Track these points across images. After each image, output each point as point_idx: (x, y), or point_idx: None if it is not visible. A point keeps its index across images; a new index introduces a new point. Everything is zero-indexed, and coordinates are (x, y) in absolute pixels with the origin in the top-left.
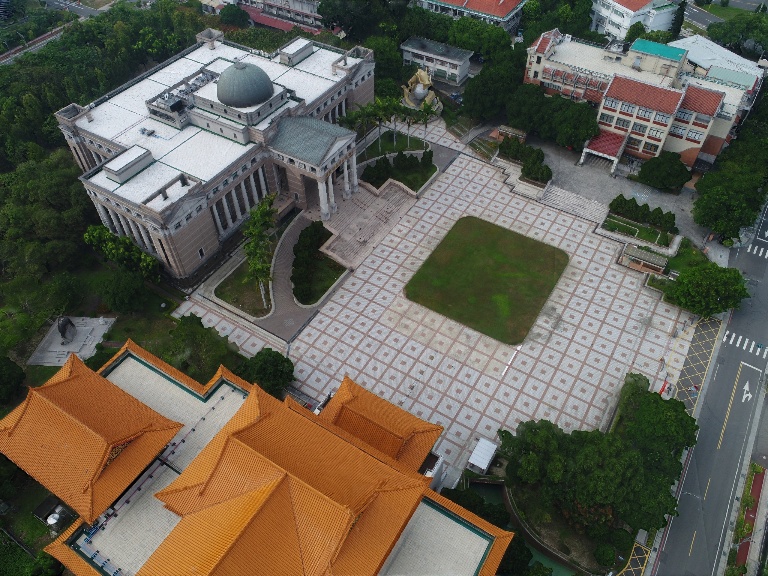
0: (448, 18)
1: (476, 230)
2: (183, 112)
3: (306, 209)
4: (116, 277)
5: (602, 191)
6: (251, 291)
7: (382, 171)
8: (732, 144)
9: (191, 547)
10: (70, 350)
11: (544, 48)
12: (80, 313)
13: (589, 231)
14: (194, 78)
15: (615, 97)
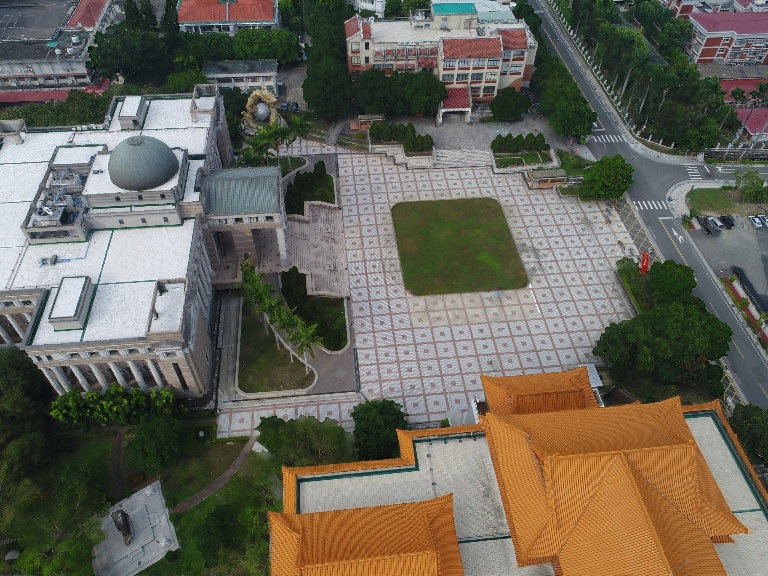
0: (225, 35)
1: (413, 213)
2: (70, 221)
3: (258, 265)
4: (147, 432)
5: (474, 139)
6: (277, 368)
7: (297, 197)
8: (537, 67)
9: (604, 568)
10: (143, 544)
11: (369, 33)
12: (112, 501)
13: (491, 174)
14: (37, 181)
15: (452, 57)
